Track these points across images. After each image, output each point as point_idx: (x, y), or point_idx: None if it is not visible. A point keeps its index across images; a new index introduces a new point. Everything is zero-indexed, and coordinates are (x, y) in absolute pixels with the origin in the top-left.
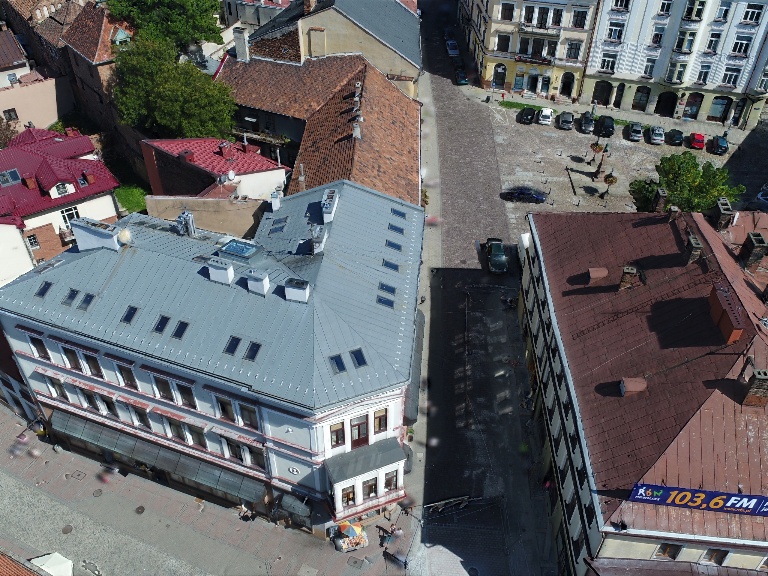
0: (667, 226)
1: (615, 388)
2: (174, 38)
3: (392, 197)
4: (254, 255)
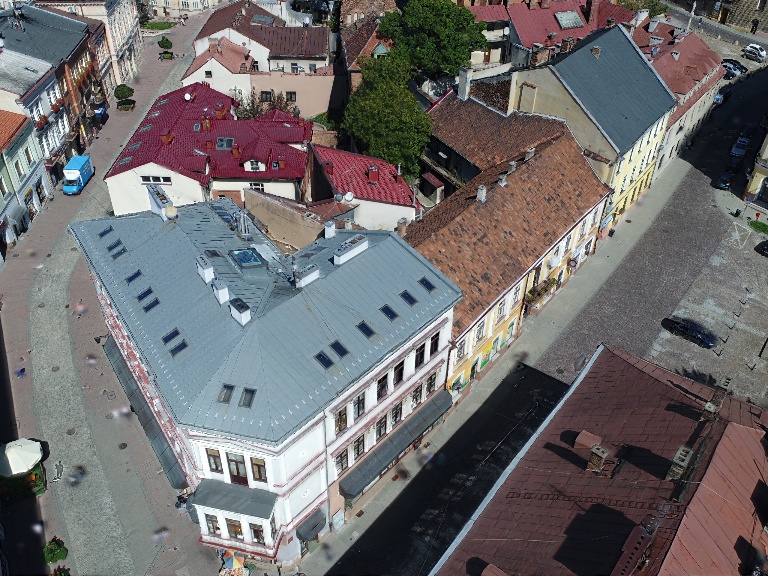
0: (693, 424)
1: (482, 571)
2: (418, 63)
3: (433, 266)
4: (252, 267)
